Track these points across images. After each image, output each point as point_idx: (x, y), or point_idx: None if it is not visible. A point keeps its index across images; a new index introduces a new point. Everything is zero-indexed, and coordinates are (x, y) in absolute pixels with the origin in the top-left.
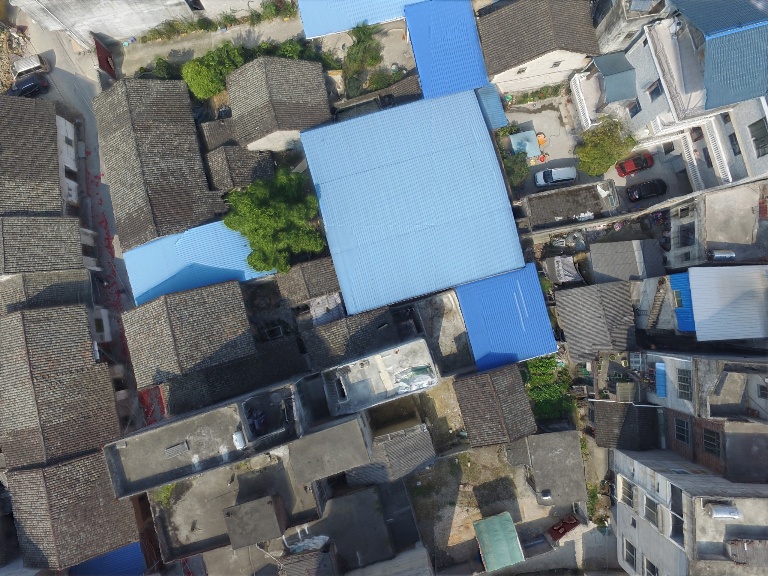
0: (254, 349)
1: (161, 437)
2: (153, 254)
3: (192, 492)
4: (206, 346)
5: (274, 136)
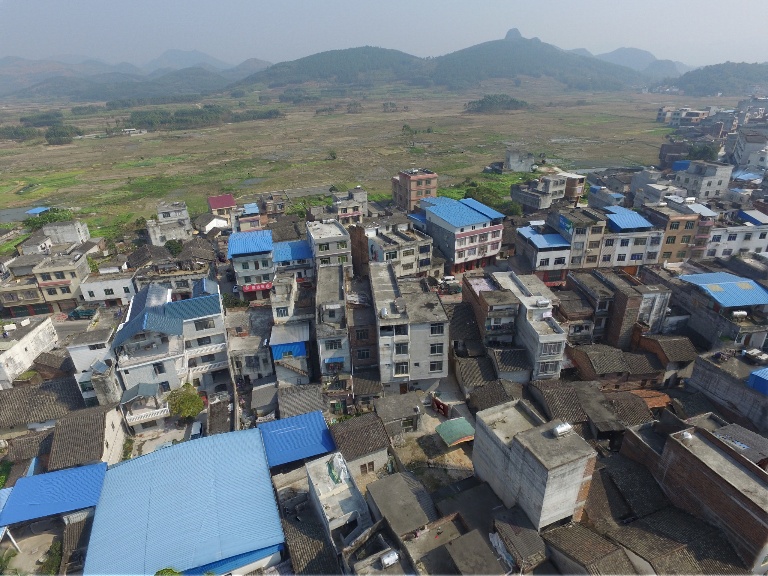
0: None
1: None
2: None
3: None
4: None
5: None
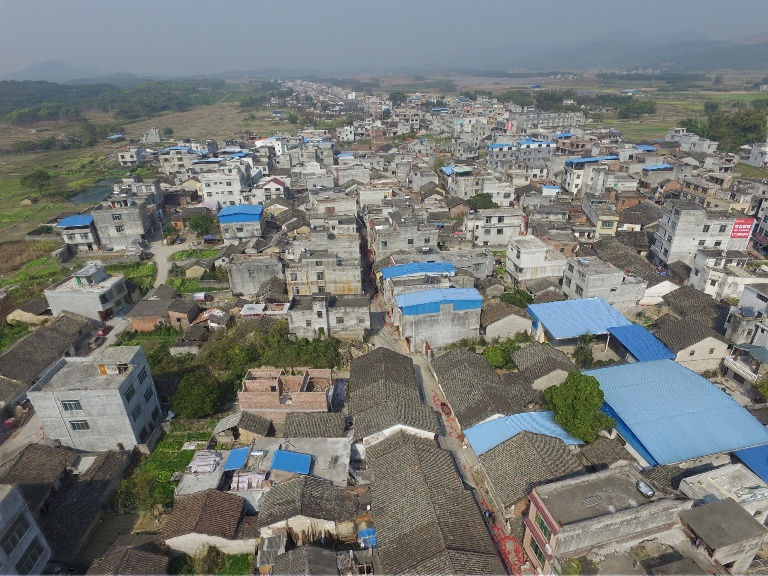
0: None
1: (575, 492)
2: (489, 428)
3: (601, 575)
4: (562, 468)
5: (552, 376)
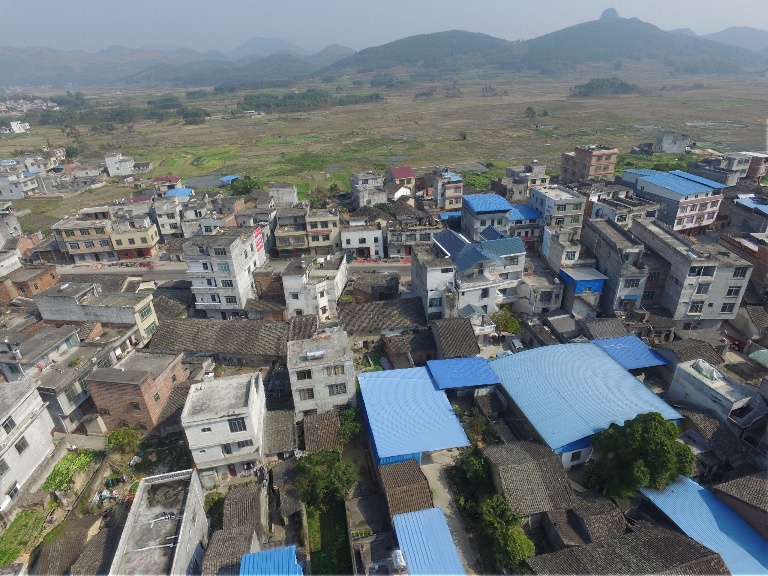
0: None
1: None
2: None
3: None
4: None
5: None
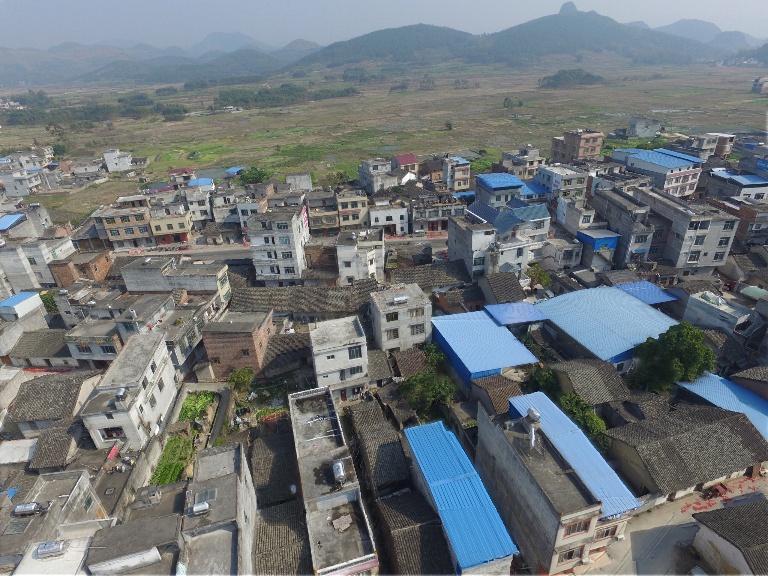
0: (766, 363)
1: None
2: (759, 428)
3: None
4: None
5: None
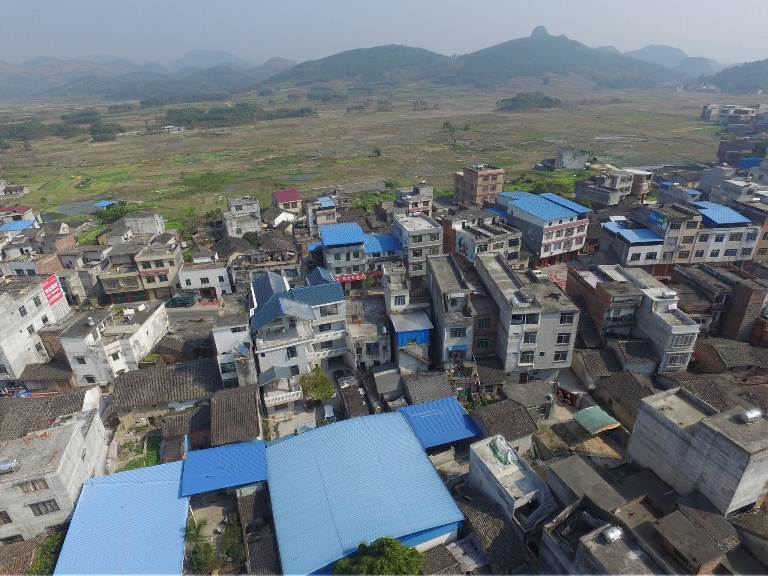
0: None
1: None
2: None
3: None
4: None
5: None
